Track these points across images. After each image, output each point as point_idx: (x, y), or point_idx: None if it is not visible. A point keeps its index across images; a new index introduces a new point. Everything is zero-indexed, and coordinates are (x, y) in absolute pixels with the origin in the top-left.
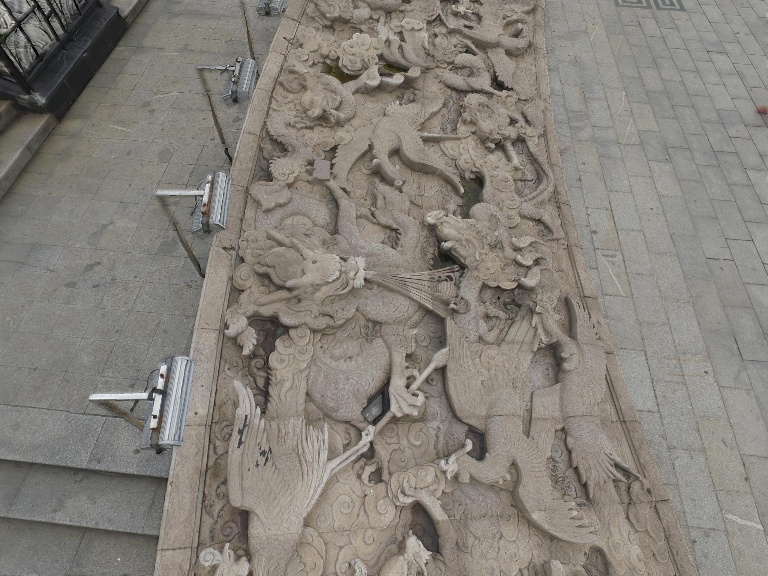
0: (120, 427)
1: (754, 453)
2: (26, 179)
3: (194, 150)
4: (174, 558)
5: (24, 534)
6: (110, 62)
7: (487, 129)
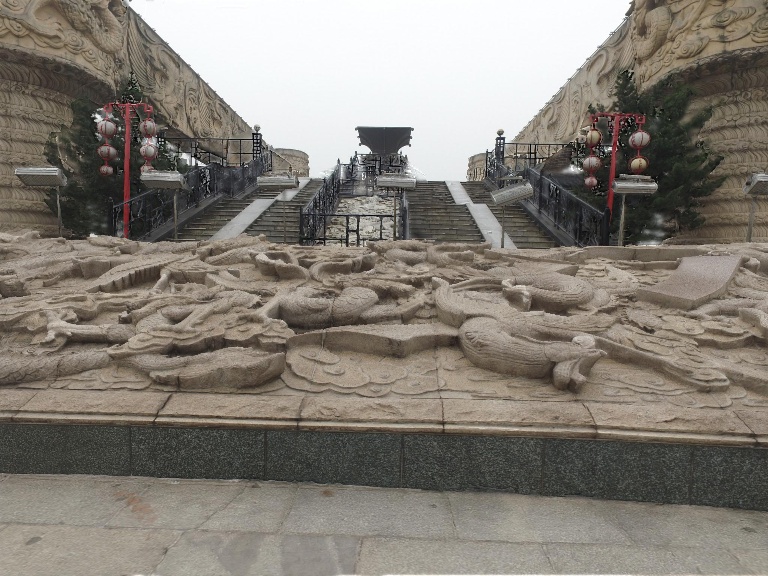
0: None
1: None
2: None
3: None
4: None
5: None
6: None
7: None
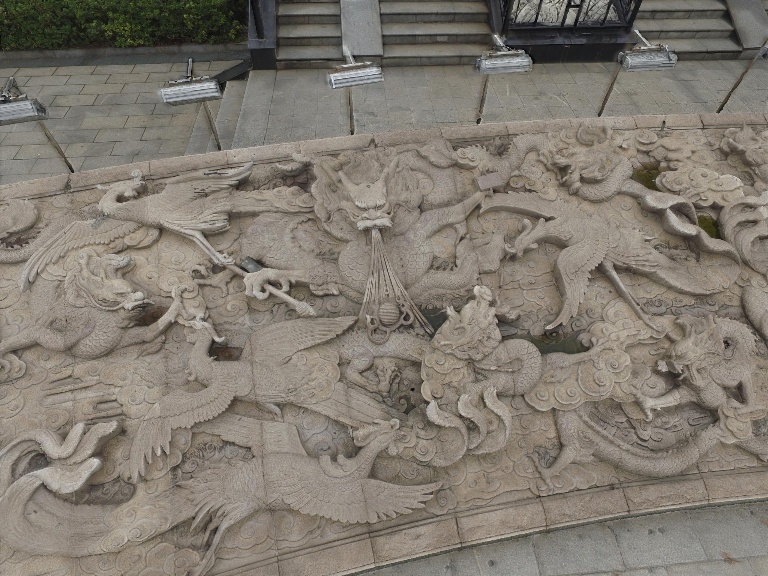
0: None
1: None
2: (437, 69)
3: None
4: (144, 167)
5: None
6: (579, 65)
7: (681, 349)
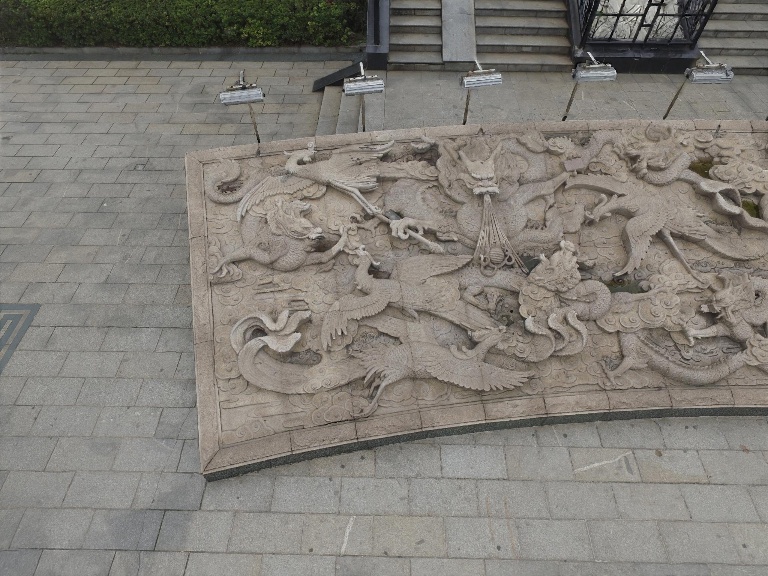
0: None
1: (413, 575)
2: (521, 74)
3: None
4: (312, 141)
5: None
6: (646, 76)
7: (721, 295)
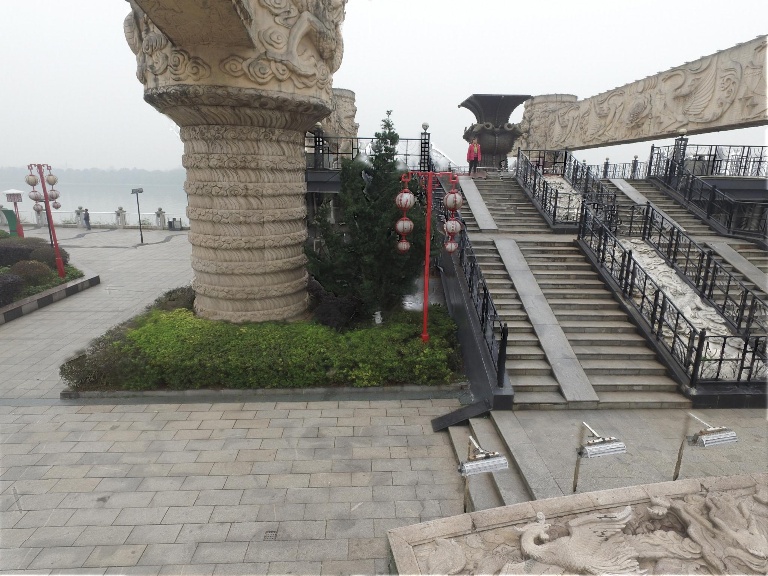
0: (559, 495)
1: None
2: (645, 412)
3: (759, 470)
4: (530, 508)
5: (487, 487)
6: (763, 411)
7: None
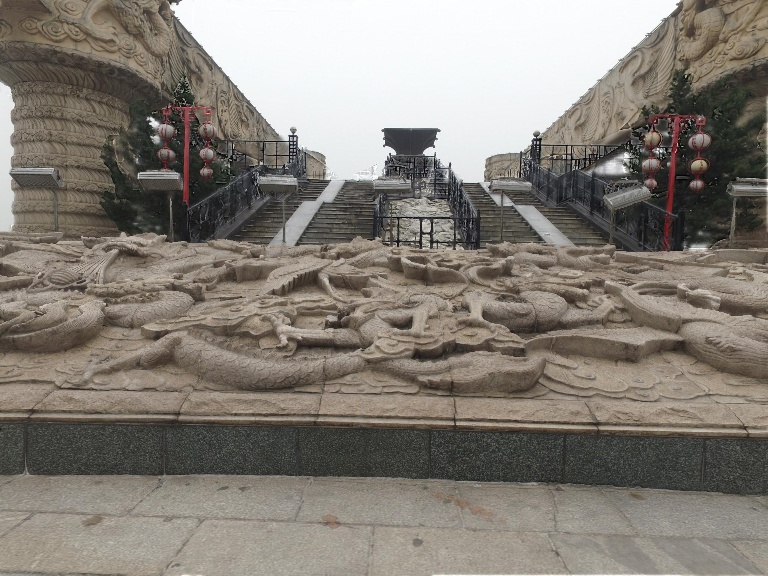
0: None
1: None
2: None
3: None
4: None
5: None
6: None
7: None
